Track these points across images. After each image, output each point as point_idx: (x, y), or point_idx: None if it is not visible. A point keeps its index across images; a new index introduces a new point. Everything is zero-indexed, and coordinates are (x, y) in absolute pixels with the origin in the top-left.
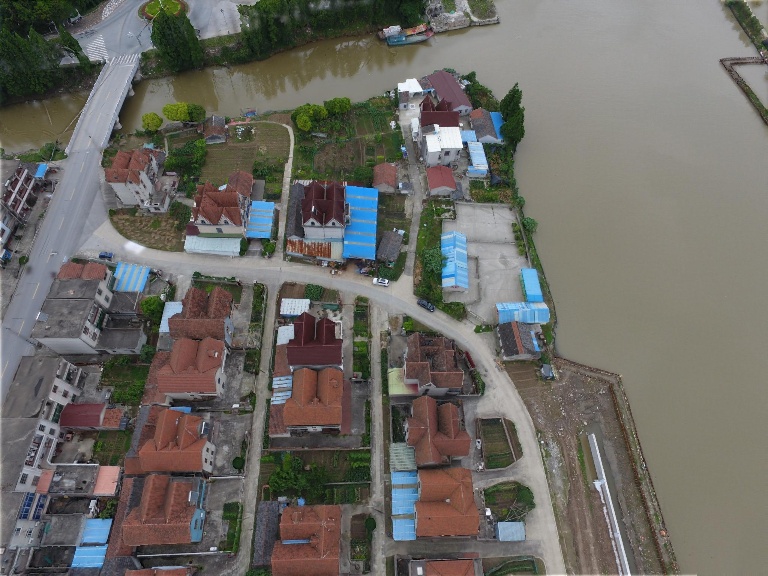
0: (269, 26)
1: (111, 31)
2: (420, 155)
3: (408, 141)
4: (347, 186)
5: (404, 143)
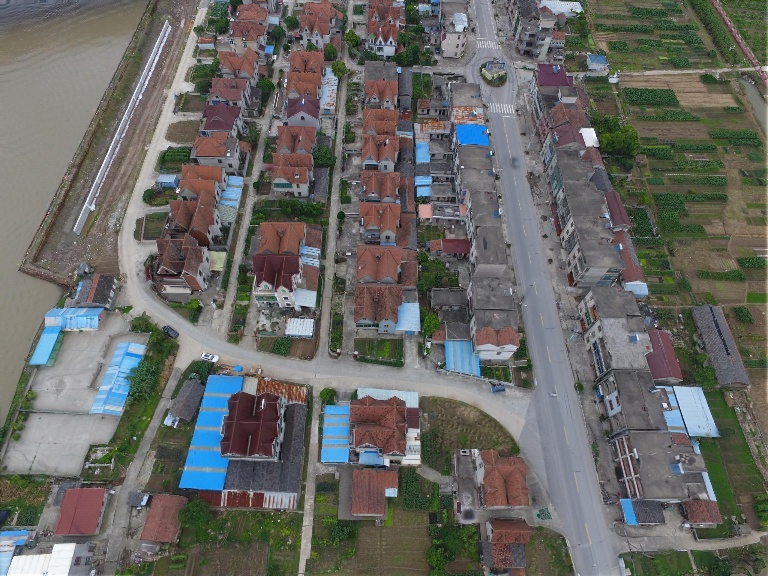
0: None
1: None
2: None
3: None
4: (221, 489)
5: None
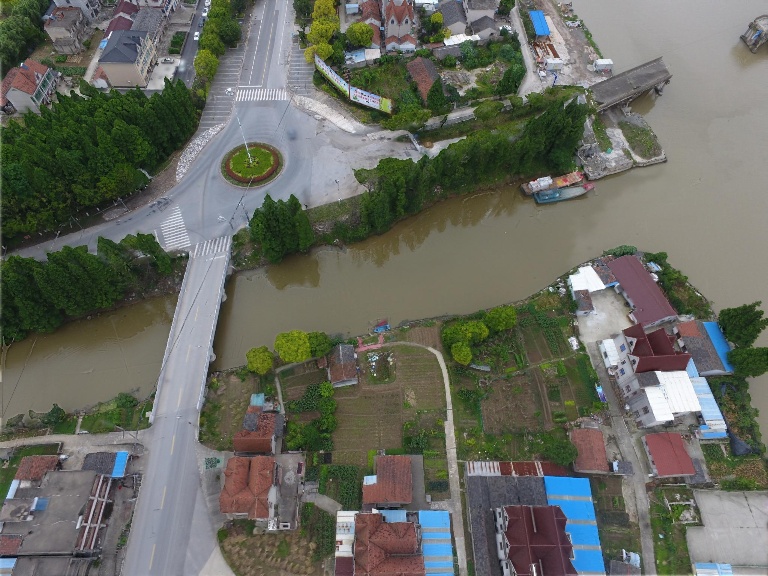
0: (398, 200)
1: (190, 200)
2: (625, 402)
3: (601, 373)
4: (546, 477)
5: (596, 377)
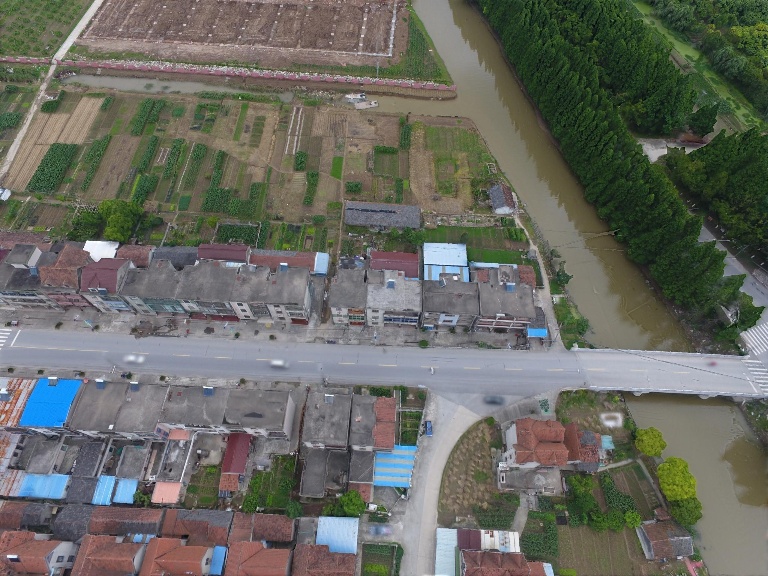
0: None
1: None
2: None
3: None
4: None
5: None
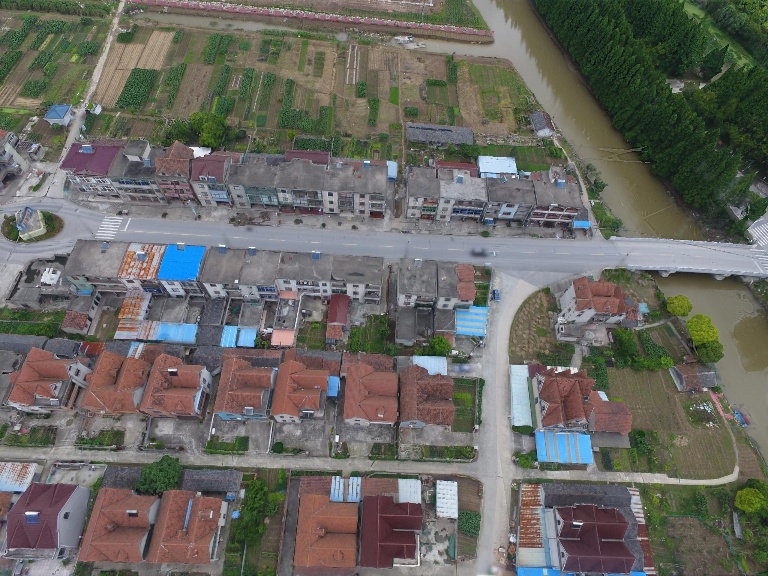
0: None
1: None
2: None
3: None
4: (645, 575)
5: None
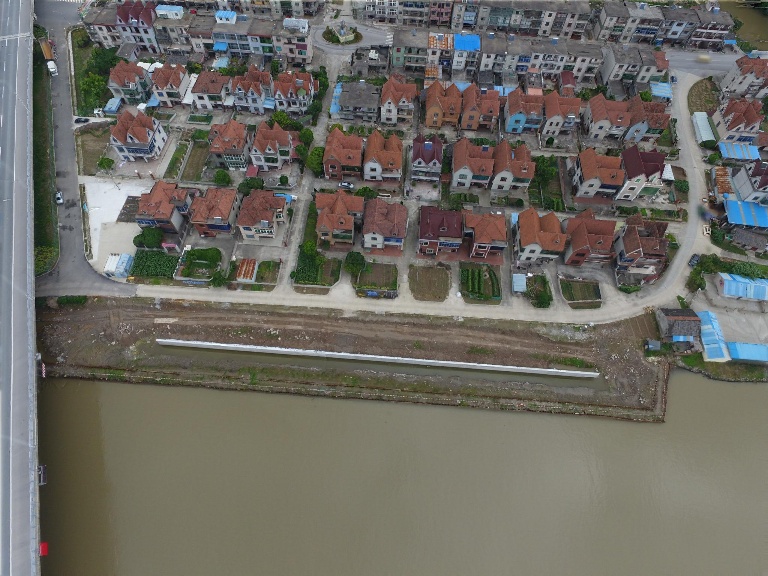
0: None
1: None
2: None
3: None
4: None
5: None
